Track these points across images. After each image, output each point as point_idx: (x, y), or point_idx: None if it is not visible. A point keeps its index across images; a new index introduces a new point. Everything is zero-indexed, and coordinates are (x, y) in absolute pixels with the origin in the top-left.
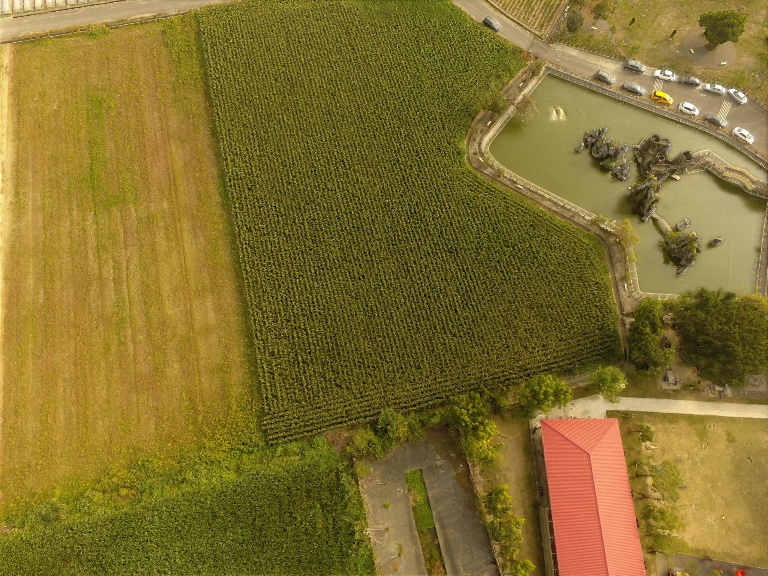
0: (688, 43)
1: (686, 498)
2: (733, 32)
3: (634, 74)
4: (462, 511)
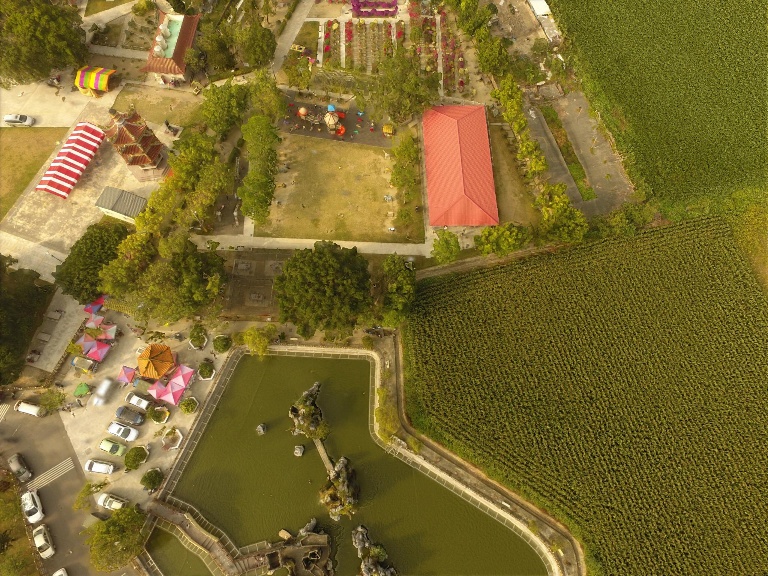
0: None
1: (367, 180)
2: None
3: None
4: (549, 173)
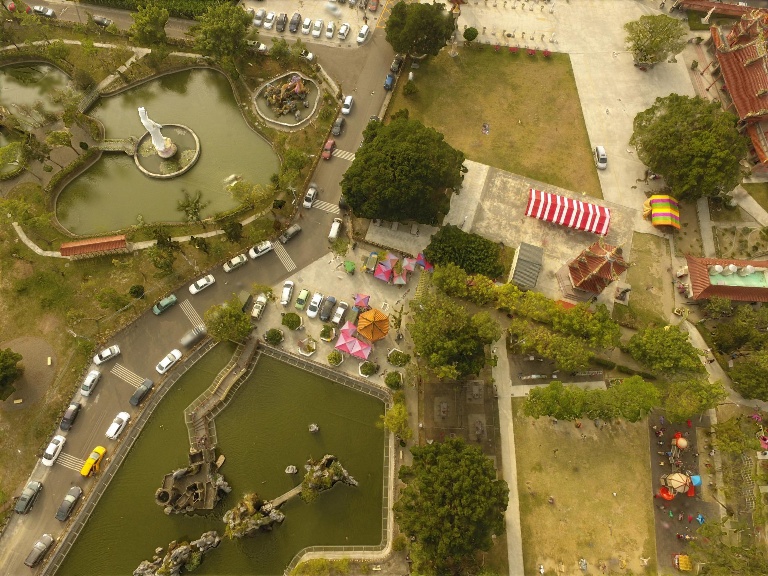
0: (2, 402)
1: (604, 533)
2: (3, 368)
3: (41, 497)
4: None
